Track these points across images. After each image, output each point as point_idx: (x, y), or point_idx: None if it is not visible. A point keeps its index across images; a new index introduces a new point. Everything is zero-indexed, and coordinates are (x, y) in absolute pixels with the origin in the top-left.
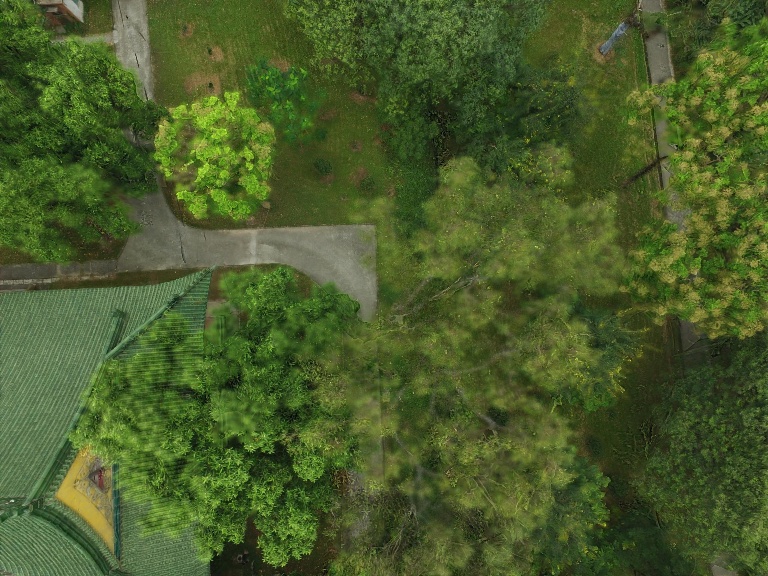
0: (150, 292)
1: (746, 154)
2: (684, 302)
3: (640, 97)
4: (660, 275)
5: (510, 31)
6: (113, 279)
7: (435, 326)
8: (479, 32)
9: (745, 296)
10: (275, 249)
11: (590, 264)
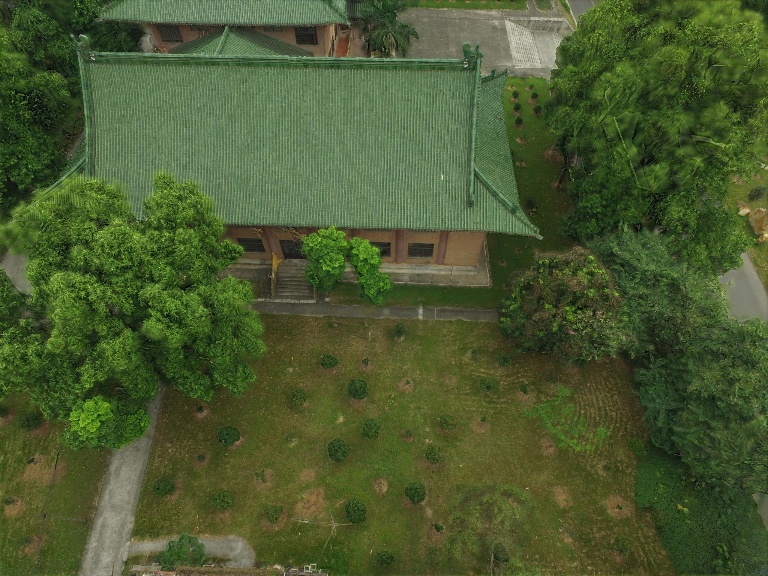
0: None
1: None
2: None
3: None
4: None
5: None
6: None
7: None
8: None
9: None
10: None
11: None
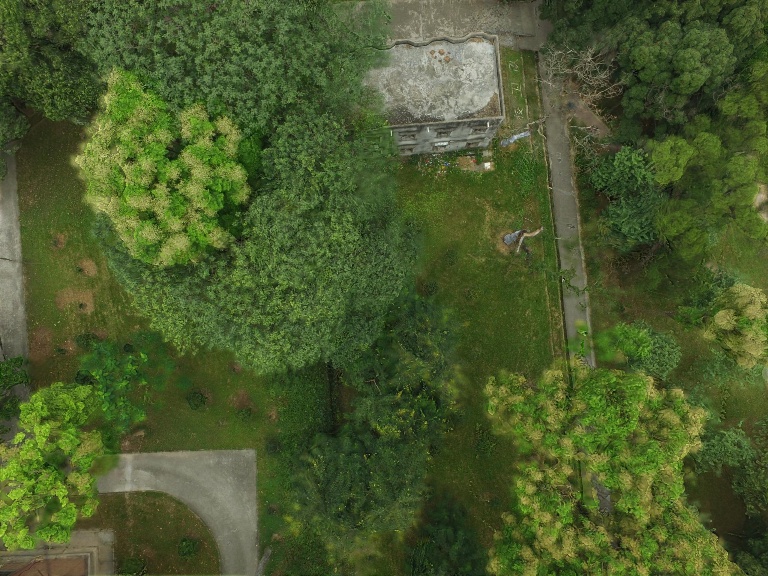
0: None
1: (595, 482)
2: None
3: (496, 394)
4: None
5: (370, 301)
6: None
7: (323, 546)
8: (314, 347)
9: None
10: (151, 475)
11: (490, 468)
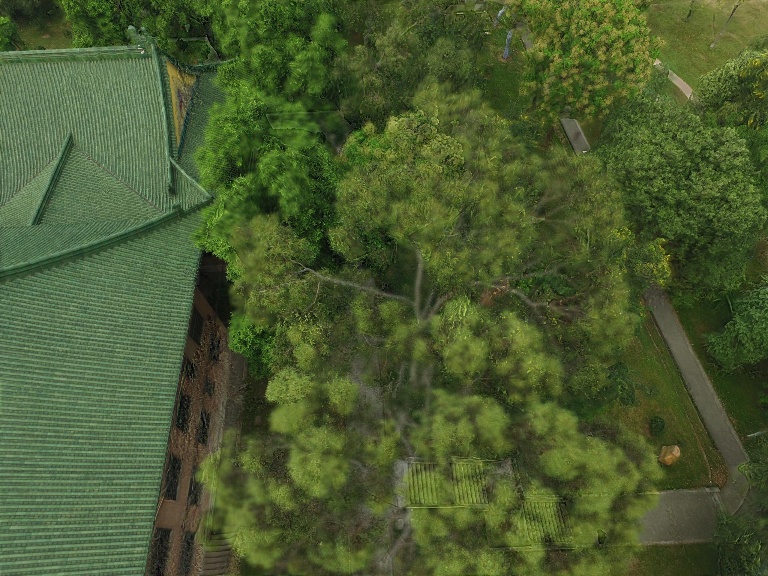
0: None
1: None
2: (552, 65)
3: None
4: (536, 58)
5: None
6: None
7: None
8: None
9: (585, 54)
10: (294, 122)
11: None
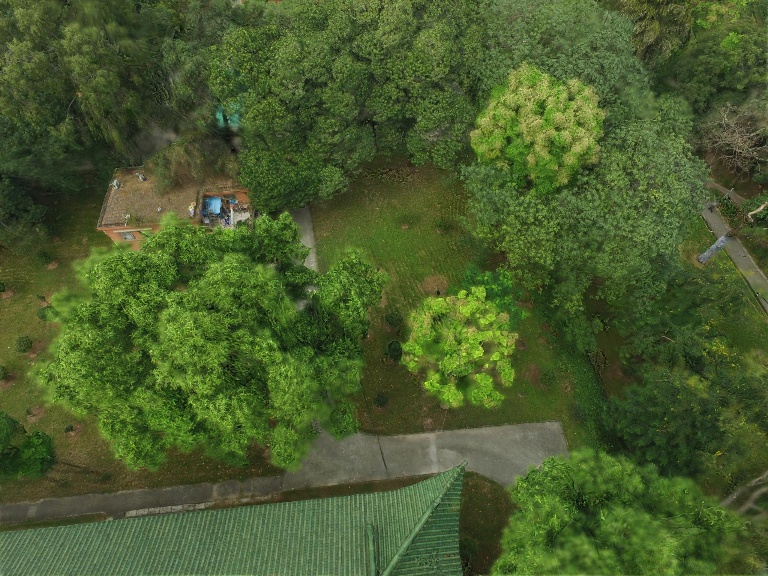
0: (392, 499)
1: None
2: None
3: None
4: None
5: None
6: (277, 500)
7: None
8: (673, 235)
9: None
10: (457, 454)
11: None
